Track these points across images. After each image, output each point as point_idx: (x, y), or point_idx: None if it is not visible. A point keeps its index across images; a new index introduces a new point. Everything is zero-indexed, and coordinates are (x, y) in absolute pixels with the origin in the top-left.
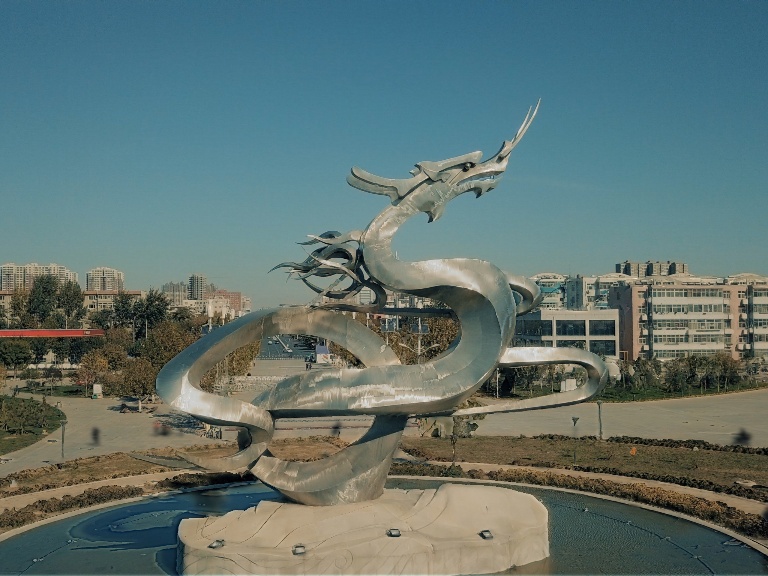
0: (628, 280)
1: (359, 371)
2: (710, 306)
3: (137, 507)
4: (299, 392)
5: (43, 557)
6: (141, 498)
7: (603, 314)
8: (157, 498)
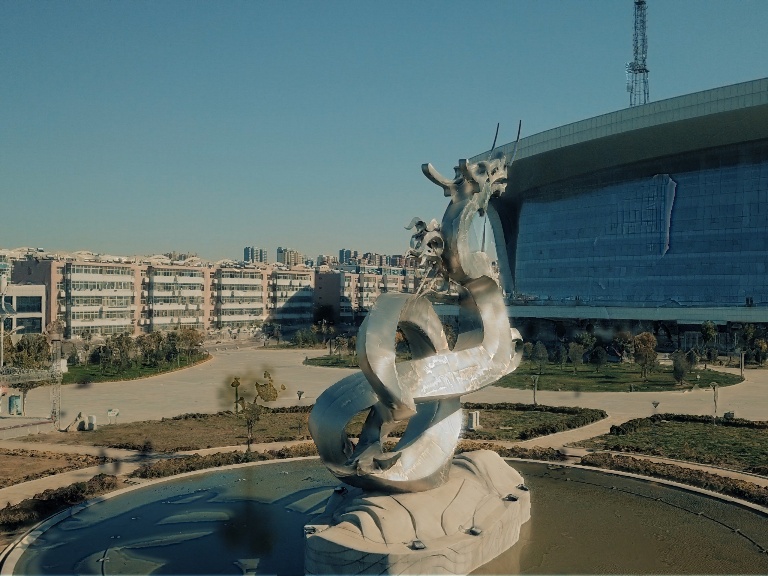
0: (35, 254)
1: (456, 355)
2: (120, 283)
3: (45, 560)
4: (420, 379)
5: None
6: (21, 550)
7: (31, 290)
8: (32, 546)
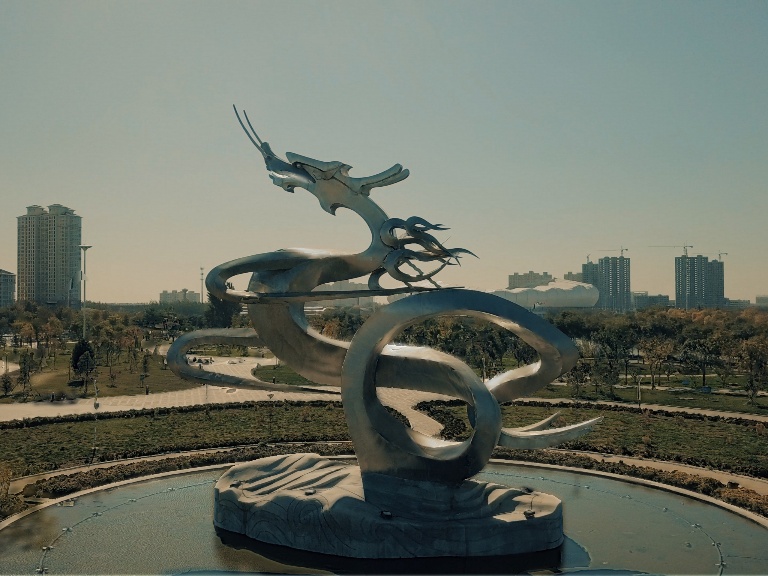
0: None
1: None
2: None
3: None
4: None
5: (722, 570)
6: None
7: None
8: None
